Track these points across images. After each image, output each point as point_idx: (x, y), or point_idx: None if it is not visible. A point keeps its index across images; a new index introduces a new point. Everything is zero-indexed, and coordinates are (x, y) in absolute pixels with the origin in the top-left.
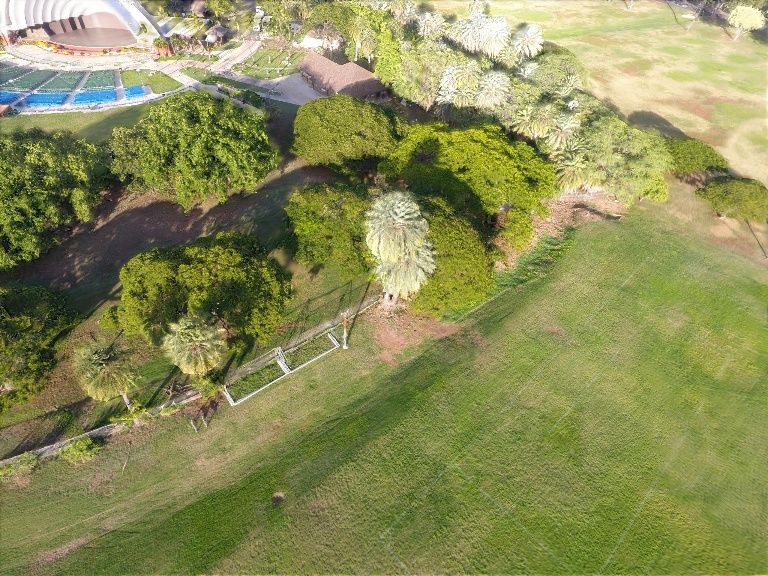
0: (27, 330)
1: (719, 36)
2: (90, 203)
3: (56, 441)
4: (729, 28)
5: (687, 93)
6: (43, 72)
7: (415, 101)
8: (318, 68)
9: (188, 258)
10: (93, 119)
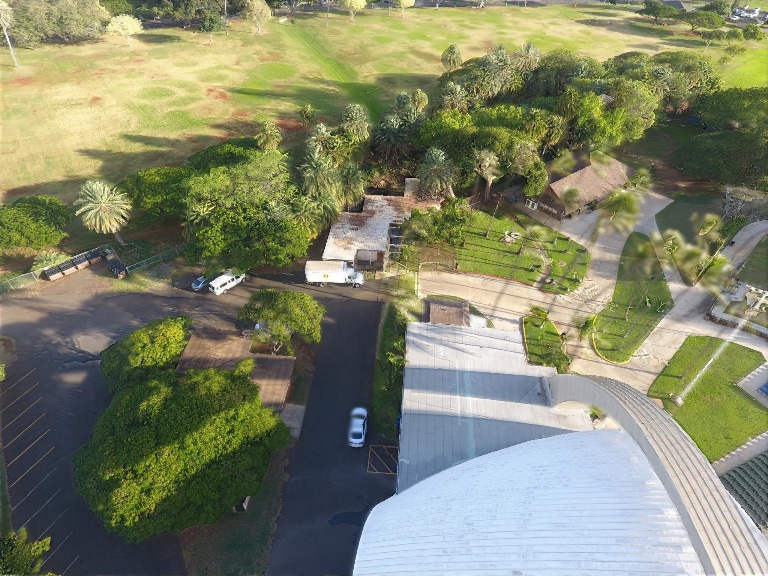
0: None
1: (341, 22)
2: None
3: None
4: (319, 16)
5: (480, 52)
6: None
7: (642, 132)
8: (586, 188)
9: None
10: None
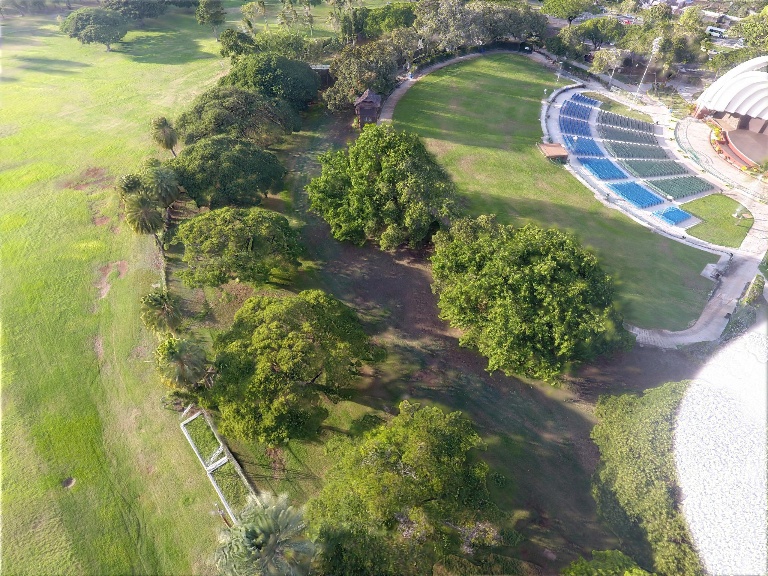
0: (245, 260)
1: None
2: (395, 242)
3: (183, 317)
4: None
5: None
6: (659, 150)
7: None
8: None
9: (298, 326)
10: (584, 205)
